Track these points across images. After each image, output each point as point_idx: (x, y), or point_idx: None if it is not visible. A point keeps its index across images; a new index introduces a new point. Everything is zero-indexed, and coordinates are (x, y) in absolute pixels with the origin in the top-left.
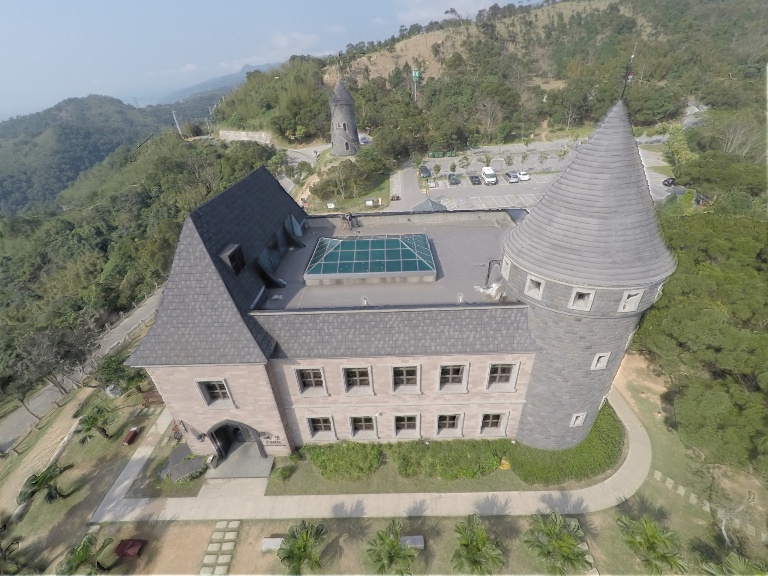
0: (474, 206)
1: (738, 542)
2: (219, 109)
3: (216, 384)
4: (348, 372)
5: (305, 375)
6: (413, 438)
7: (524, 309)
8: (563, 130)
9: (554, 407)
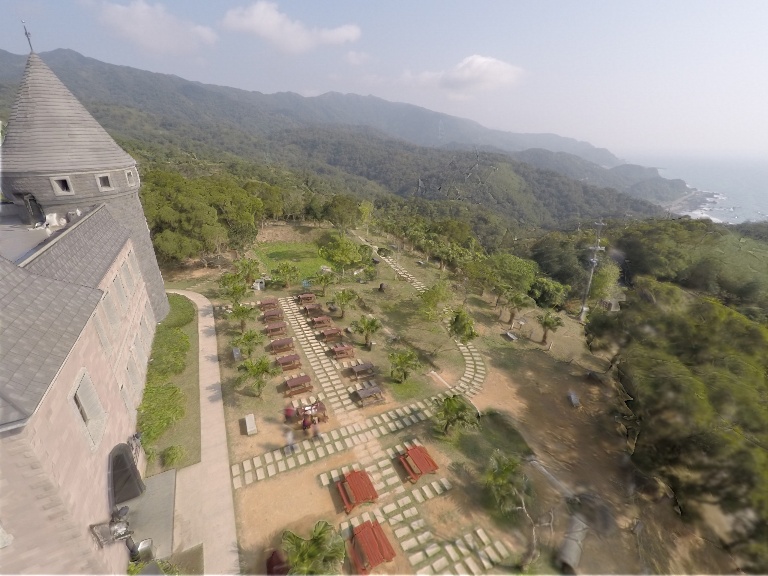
0: None
1: None
2: None
3: None
4: None
5: None
6: None
7: (104, 207)
8: None
9: (155, 272)
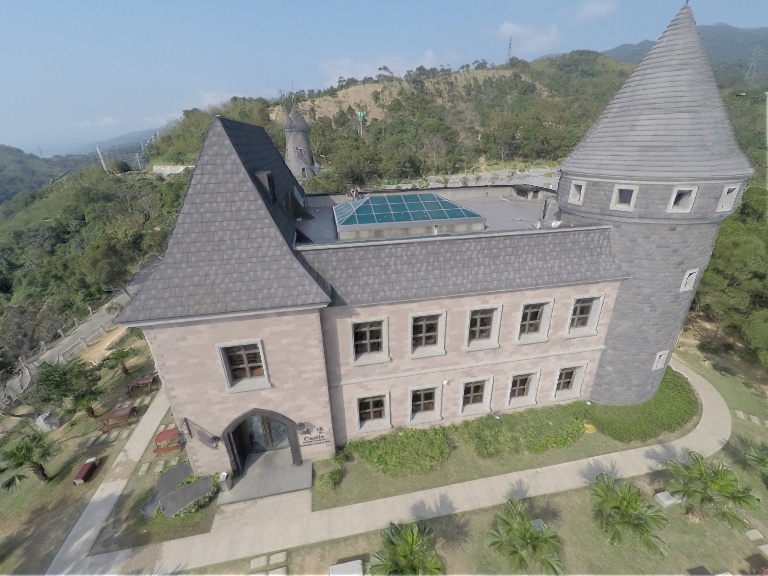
0: None
1: None
2: (153, 144)
3: (243, 354)
4: (413, 326)
5: (359, 336)
6: (481, 413)
7: (607, 230)
8: (498, 164)
9: (639, 346)
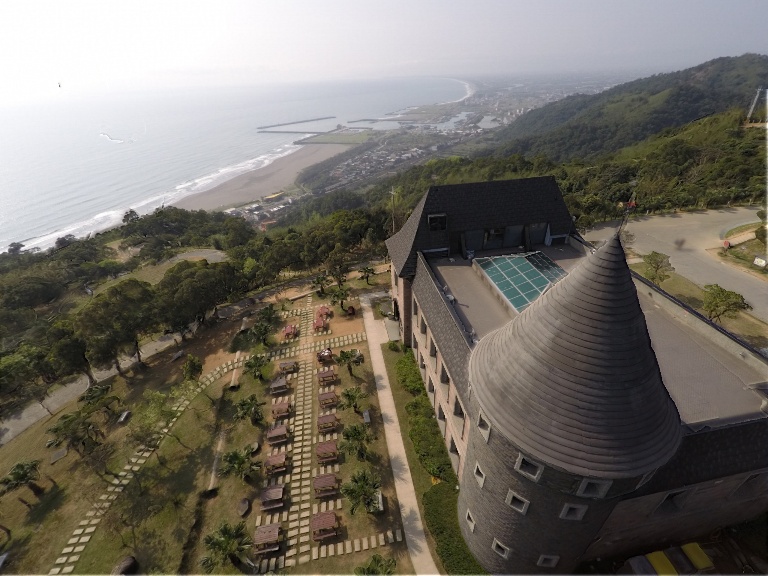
0: None
1: None
2: None
3: None
4: None
5: None
6: None
7: None
8: None
9: None
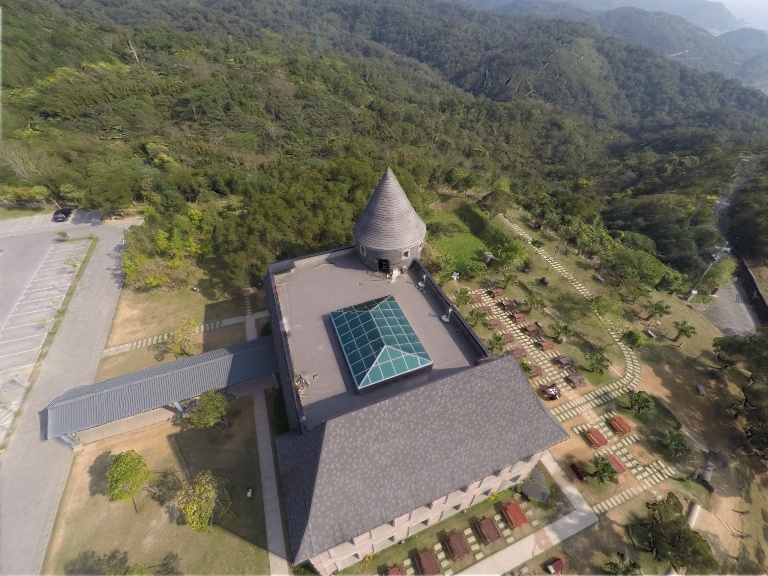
0: (16, 379)
1: None
2: None
3: None
4: None
5: None
6: None
7: None
8: None
9: None
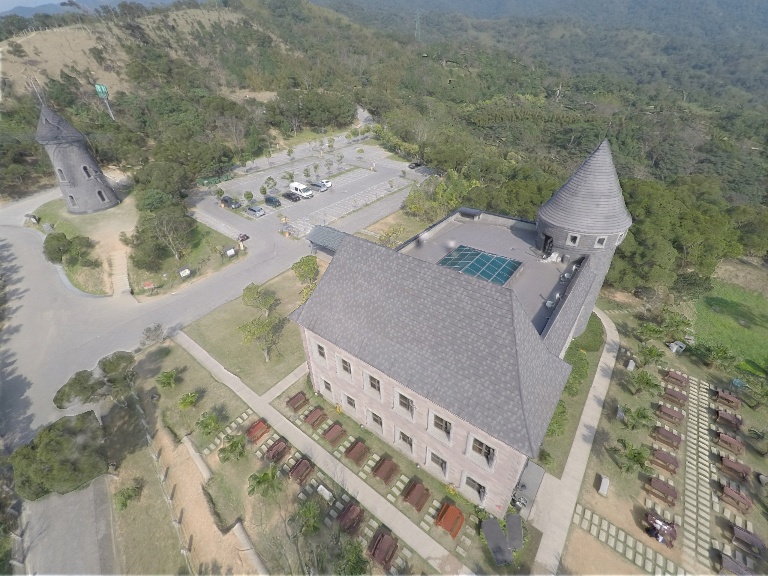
0: (326, 220)
1: (643, 315)
2: None
3: None
4: None
5: None
6: None
7: None
8: (292, 137)
9: None
